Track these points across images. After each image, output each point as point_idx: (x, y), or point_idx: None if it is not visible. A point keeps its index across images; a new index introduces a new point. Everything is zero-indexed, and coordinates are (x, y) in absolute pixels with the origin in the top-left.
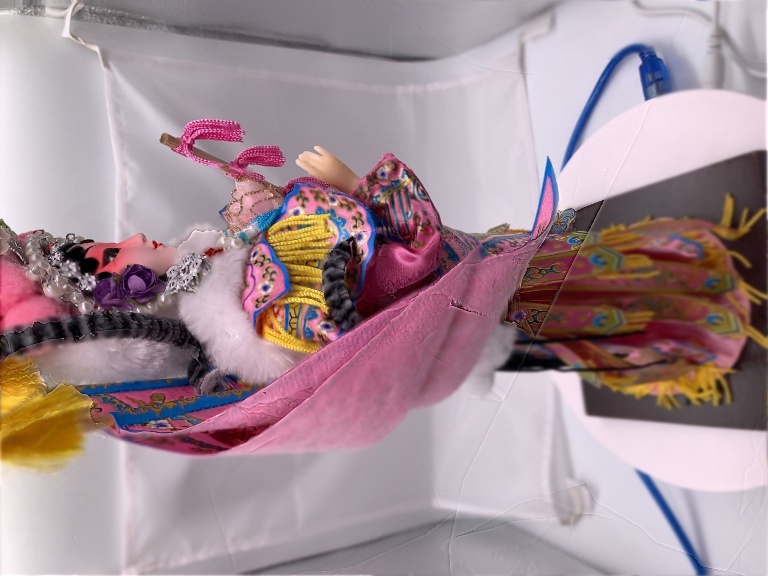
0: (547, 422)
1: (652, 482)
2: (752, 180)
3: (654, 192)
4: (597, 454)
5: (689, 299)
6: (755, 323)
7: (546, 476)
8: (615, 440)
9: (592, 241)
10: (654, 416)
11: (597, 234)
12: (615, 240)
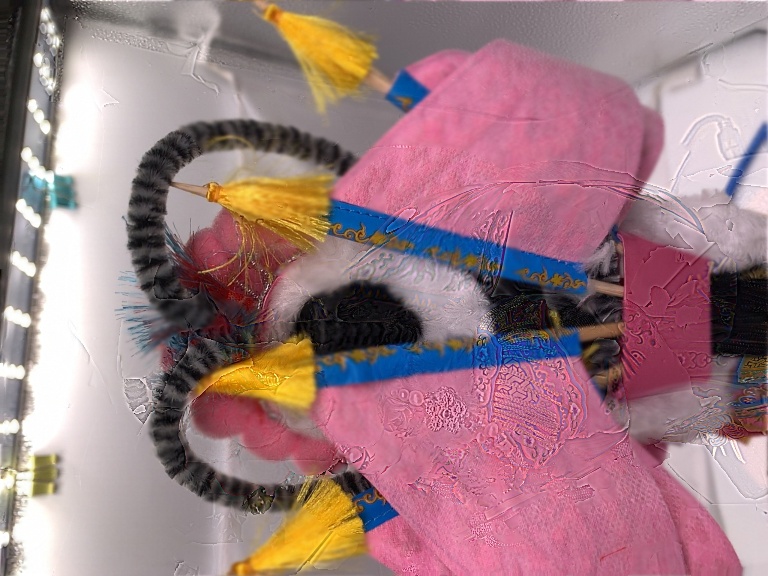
0: (239, 550)
1: (253, 538)
2: (268, 570)
3: (251, 572)
4: (245, 544)
5: (259, 558)
6: (273, 551)
7: (238, 544)
8: (248, 545)
9: (243, 569)
10: (254, 546)
11: (244, 570)
12: (246, 568)
